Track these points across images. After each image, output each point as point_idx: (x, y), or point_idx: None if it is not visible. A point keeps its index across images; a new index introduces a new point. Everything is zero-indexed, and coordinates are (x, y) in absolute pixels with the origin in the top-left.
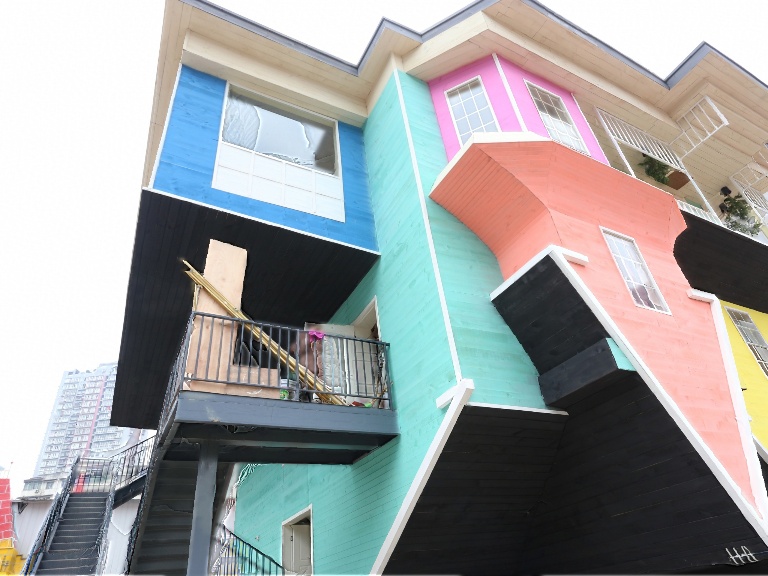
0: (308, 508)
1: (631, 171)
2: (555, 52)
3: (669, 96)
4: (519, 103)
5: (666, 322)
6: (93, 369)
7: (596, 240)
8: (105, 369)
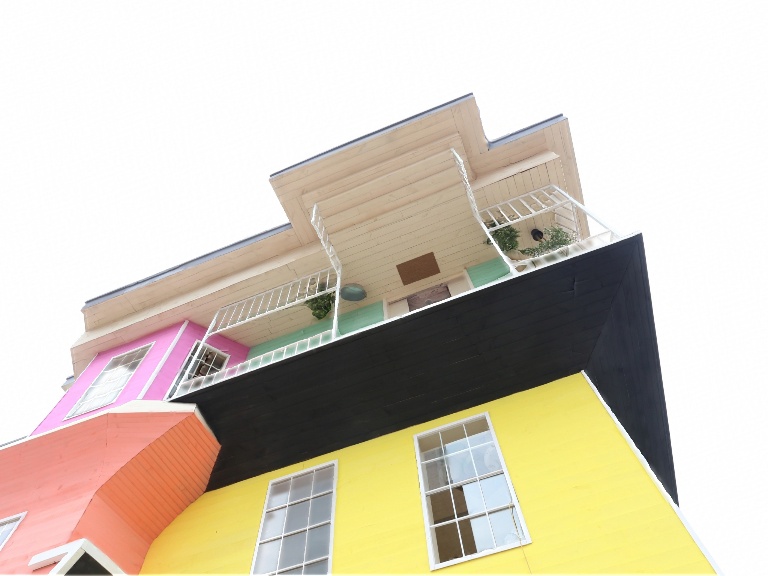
0: None
1: None
2: (159, 303)
3: (301, 230)
4: None
5: None
6: None
7: None
8: None
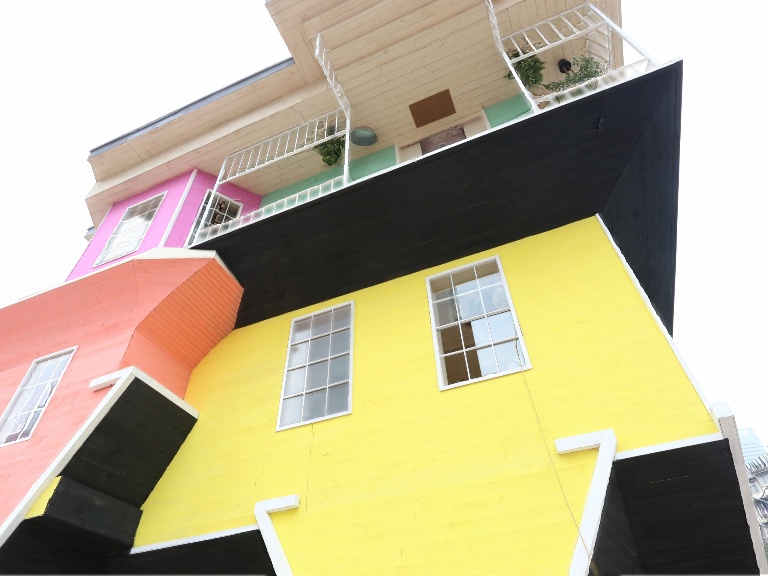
0: None
1: (201, 221)
2: (165, 151)
3: (305, 65)
4: (89, 249)
5: (4, 456)
6: None
7: (13, 383)
8: None
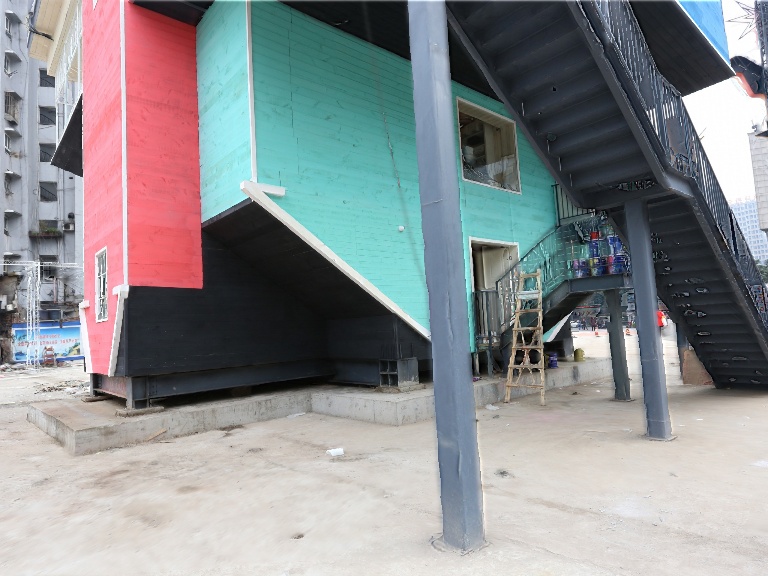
0: (515, 244)
1: None
2: None
3: None
4: None
5: None
6: None
7: None
8: None
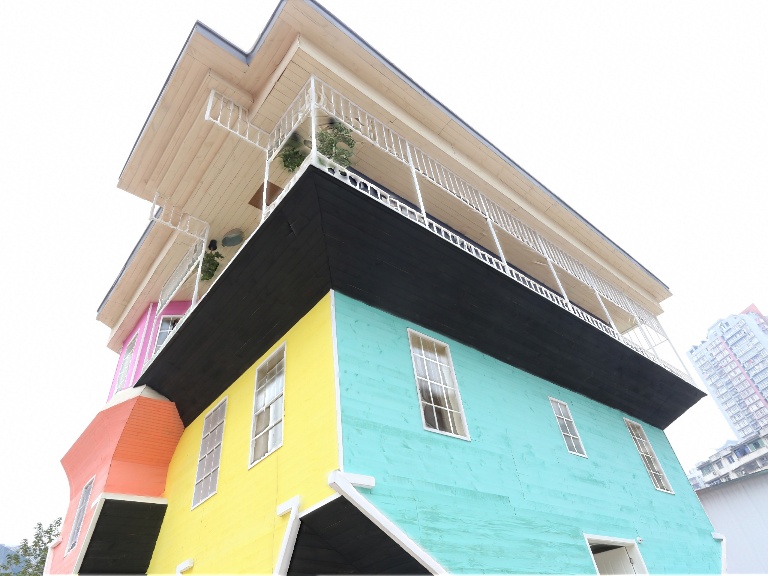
0: None
1: None
2: None
3: (171, 206)
4: (112, 386)
5: None
6: (705, 338)
7: None
8: (714, 332)
